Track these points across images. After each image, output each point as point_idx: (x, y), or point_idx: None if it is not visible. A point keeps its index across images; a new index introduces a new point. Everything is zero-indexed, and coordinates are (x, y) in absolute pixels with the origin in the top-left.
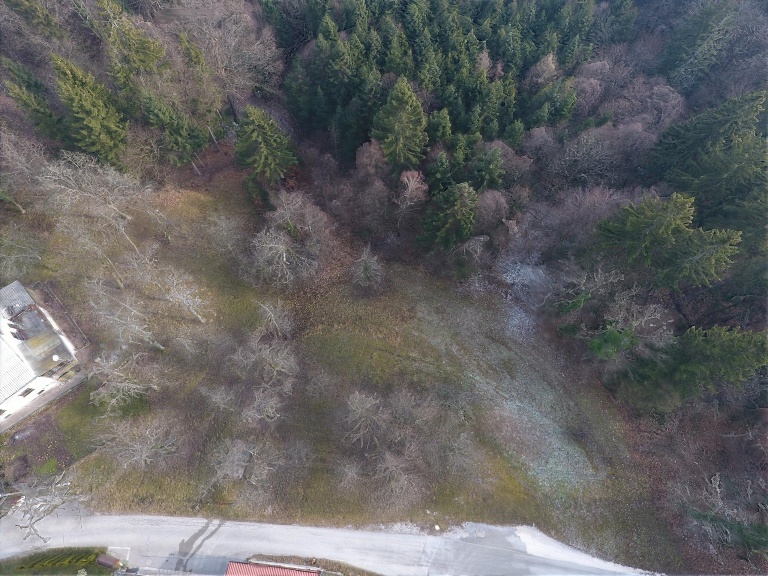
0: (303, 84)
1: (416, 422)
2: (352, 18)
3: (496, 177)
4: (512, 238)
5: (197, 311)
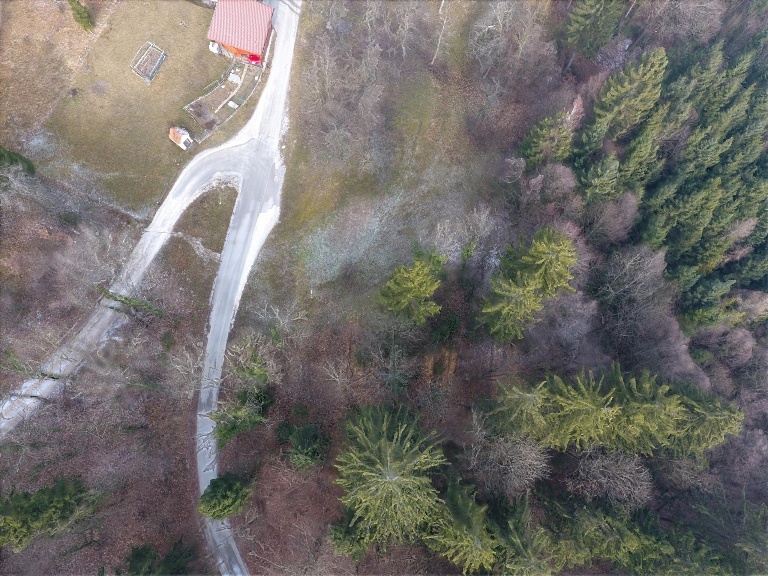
0: (673, 63)
1: (360, 105)
2: (760, 91)
3: (591, 188)
4: (526, 192)
5: (448, 7)
